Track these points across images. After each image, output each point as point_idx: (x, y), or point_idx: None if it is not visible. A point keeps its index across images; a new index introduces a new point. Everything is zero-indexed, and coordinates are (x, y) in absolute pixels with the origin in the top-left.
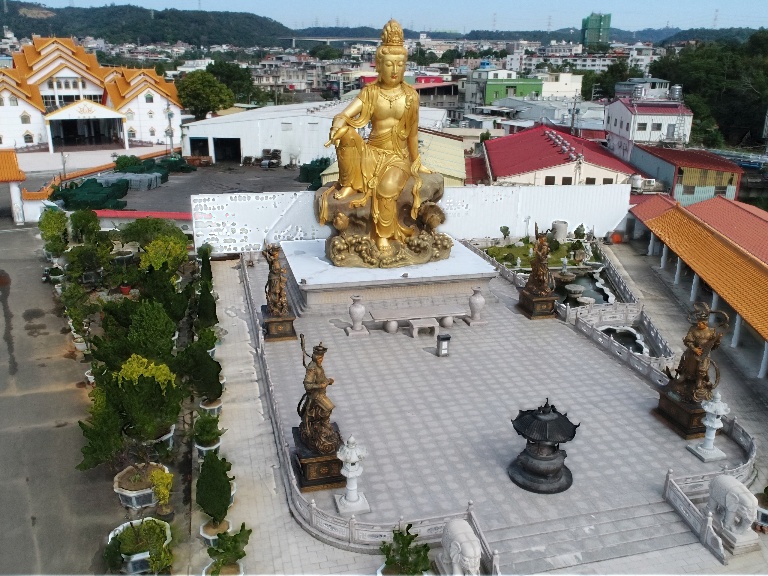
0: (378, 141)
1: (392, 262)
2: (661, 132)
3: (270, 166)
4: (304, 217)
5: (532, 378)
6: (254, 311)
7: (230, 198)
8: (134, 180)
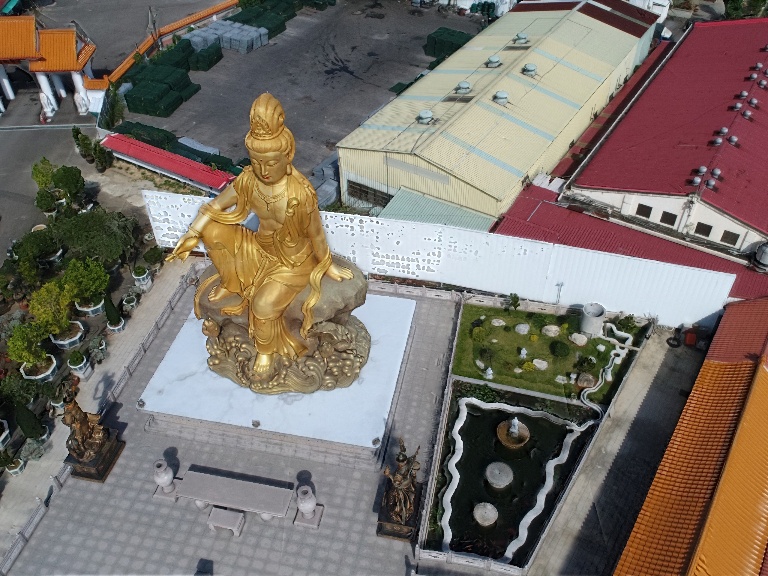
0: (260, 241)
1: (264, 388)
2: None
3: (422, 5)
4: None
5: None
6: None
7: (315, 88)
8: (234, 39)
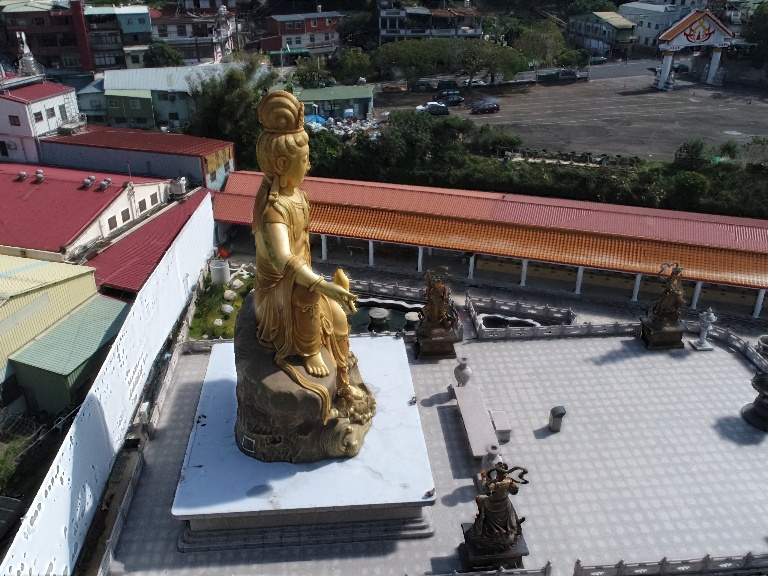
0: None
1: None
2: (57, 117)
3: None
4: (85, 463)
5: (599, 387)
6: (456, 575)
7: None
8: None
